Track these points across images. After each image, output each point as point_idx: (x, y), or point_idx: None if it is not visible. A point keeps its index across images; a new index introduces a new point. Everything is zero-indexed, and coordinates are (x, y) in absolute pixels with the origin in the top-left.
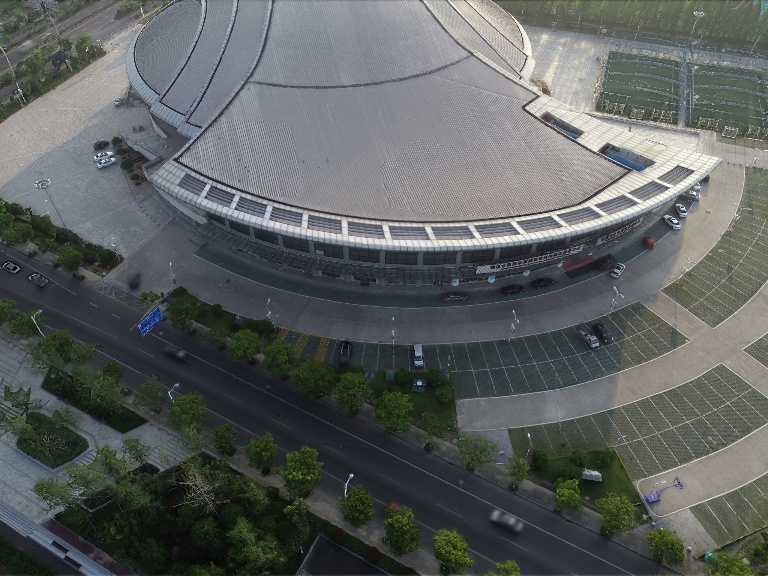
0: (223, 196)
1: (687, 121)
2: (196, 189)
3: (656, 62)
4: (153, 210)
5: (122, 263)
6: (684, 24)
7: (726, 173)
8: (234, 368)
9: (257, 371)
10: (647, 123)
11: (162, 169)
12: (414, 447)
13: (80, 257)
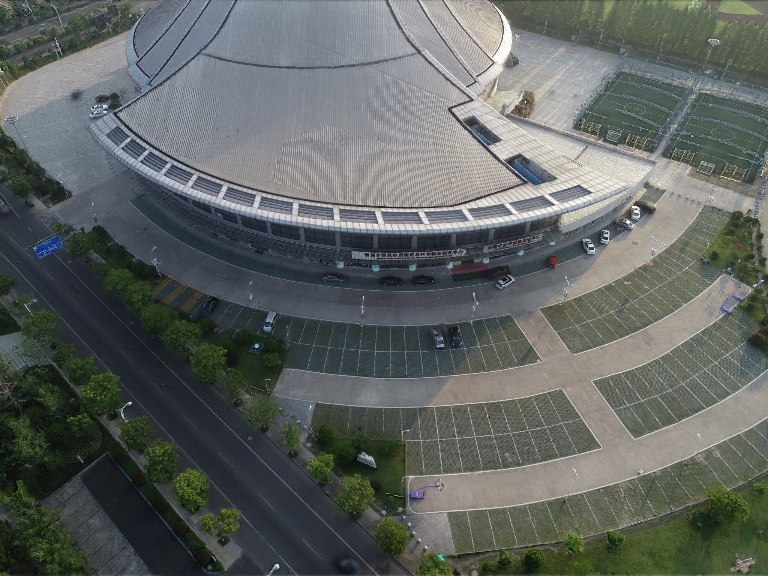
0: (137, 149)
1: (666, 151)
2: (119, 140)
3: None
4: None
5: (69, 199)
6: (712, 52)
7: (678, 208)
8: (111, 302)
9: None
10: (605, 145)
11: (101, 120)
12: (226, 400)
13: (27, 186)
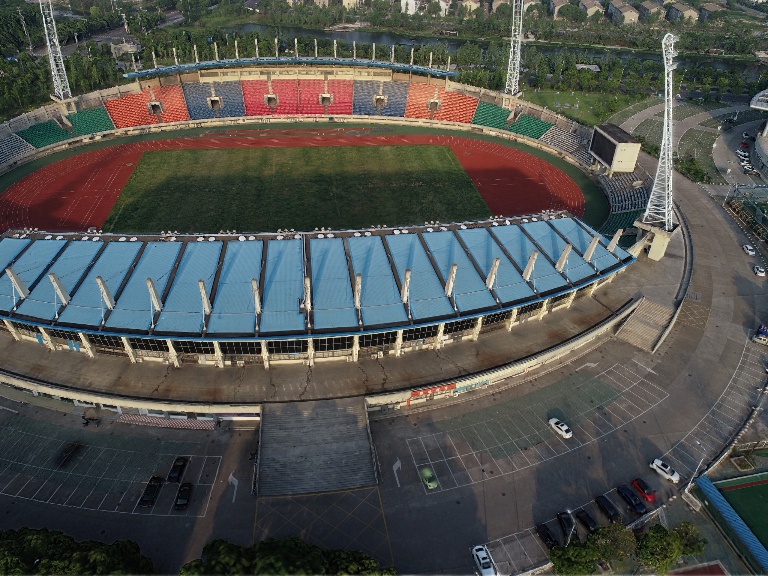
0: None
1: None
2: None
3: None
4: None
5: None
6: None
7: (738, 179)
8: None
9: None
10: None
11: None
12: None
13: None
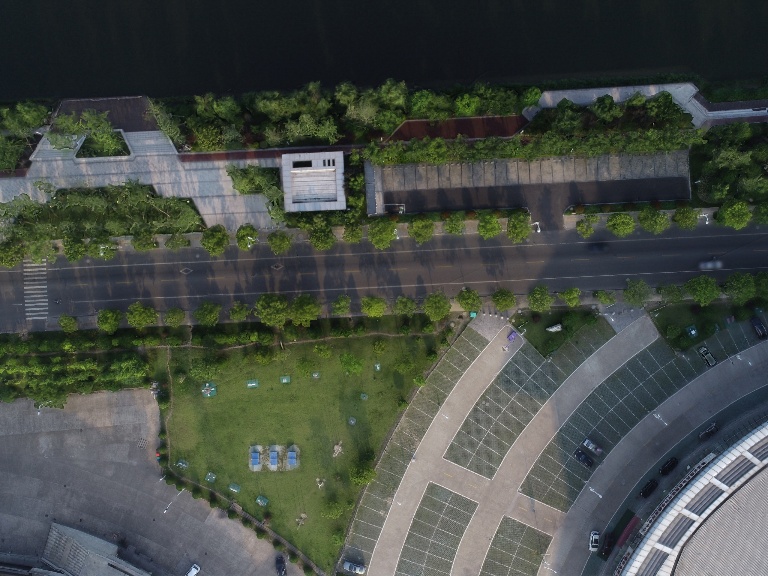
0: None
1: None
2: None
3: None
4: None
5: None
6: None
7: None
8: None
9: None
10: None
11: None
12: None
13: None
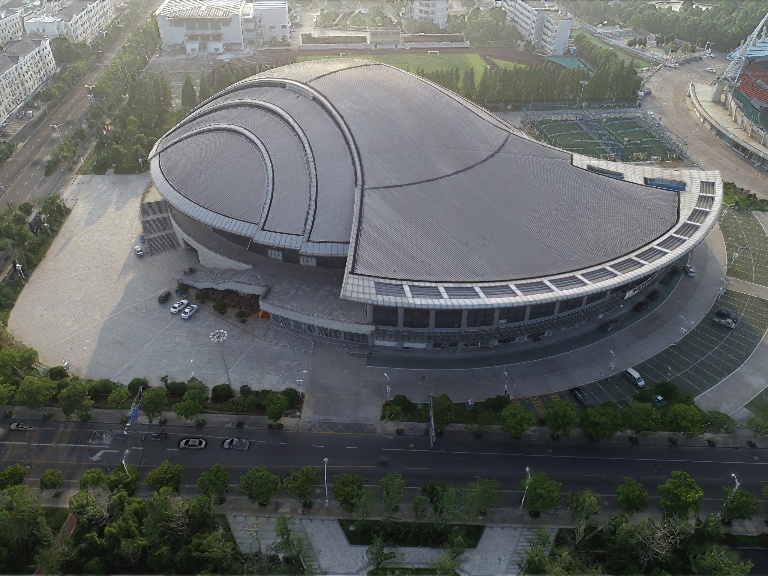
0: (426, 291)
1: (622, 159)
2: (395, 293)
3: (576, 121)
4: (285, 340)
5: (305, 398)
6: (561, 93)
7: None
8: (508, 448)
9: (528, 442)
10: None
11: (347, 285)
12: (701, 448)
13: (286, 401)
